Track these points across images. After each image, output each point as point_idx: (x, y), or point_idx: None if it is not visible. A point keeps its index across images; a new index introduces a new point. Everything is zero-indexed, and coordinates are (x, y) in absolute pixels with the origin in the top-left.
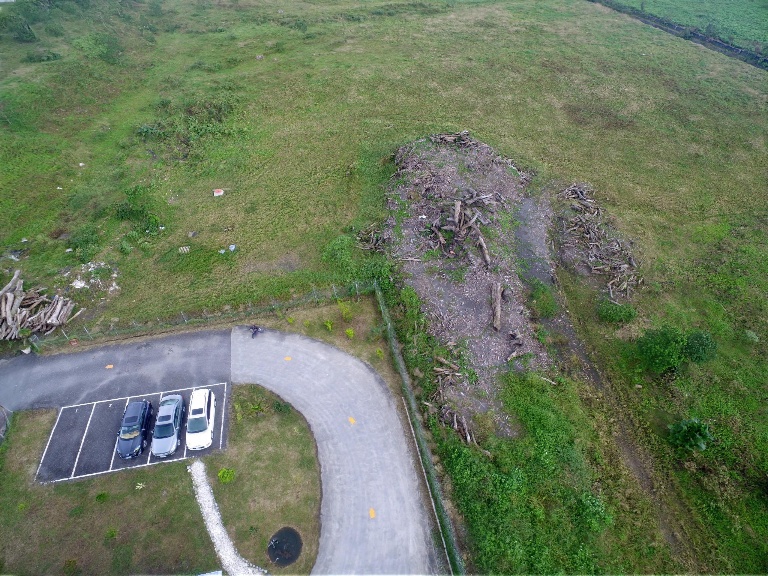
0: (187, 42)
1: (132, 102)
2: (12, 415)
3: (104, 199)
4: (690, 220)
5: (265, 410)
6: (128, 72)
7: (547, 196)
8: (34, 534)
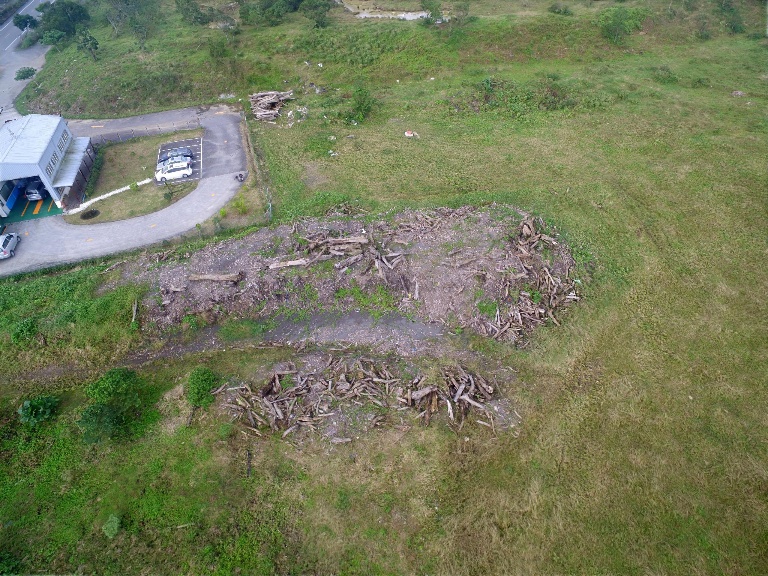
0: (731, 52)
1: (550, 67)
2: (201, 127)
3: (389, 98)
4: (420, 574)
5: (175, 194)
6: (609, 49)
7: (453, 354)
8: (137, 152)
